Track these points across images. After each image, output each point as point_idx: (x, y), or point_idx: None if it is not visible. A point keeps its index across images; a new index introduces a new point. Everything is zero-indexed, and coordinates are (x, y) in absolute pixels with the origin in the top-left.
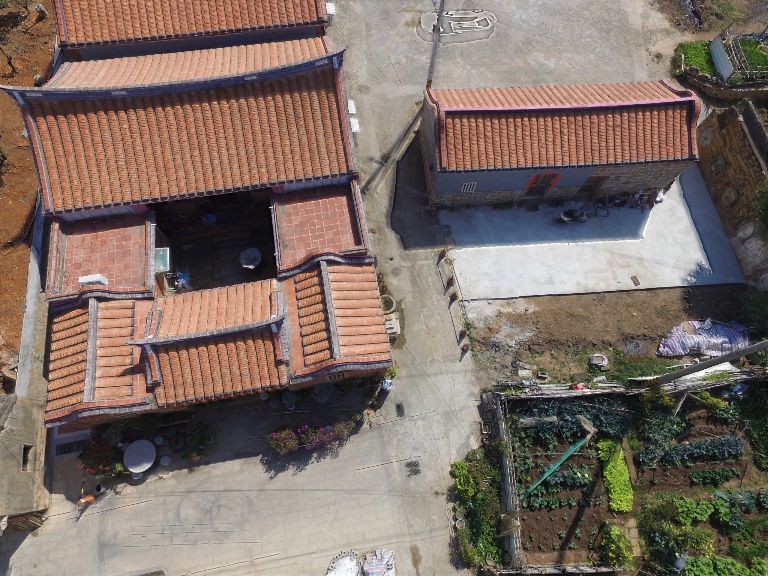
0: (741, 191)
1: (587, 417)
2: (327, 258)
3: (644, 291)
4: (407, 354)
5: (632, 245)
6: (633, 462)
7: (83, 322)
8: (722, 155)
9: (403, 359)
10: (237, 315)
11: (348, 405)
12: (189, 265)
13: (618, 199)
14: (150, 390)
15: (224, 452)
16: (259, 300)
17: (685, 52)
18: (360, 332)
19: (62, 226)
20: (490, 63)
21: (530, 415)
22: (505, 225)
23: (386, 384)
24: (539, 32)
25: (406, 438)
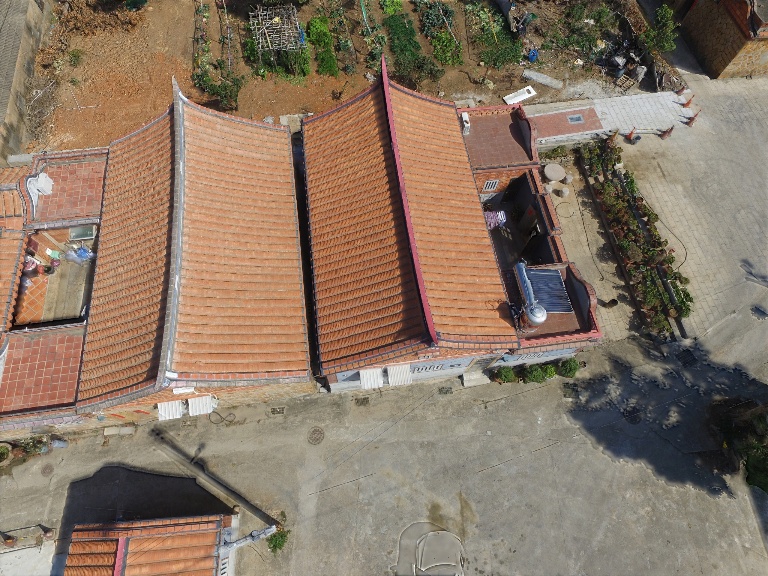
0: None
1: None
2: None
3: None
4: None
5: None
6: None
7: None
8: None
9: None
10: None
11: None
12: None
13: None
14: None
15: None
16: None
17: None
18: None
19: None
20: None
21: None
22: None
23: None
24: None
25: None
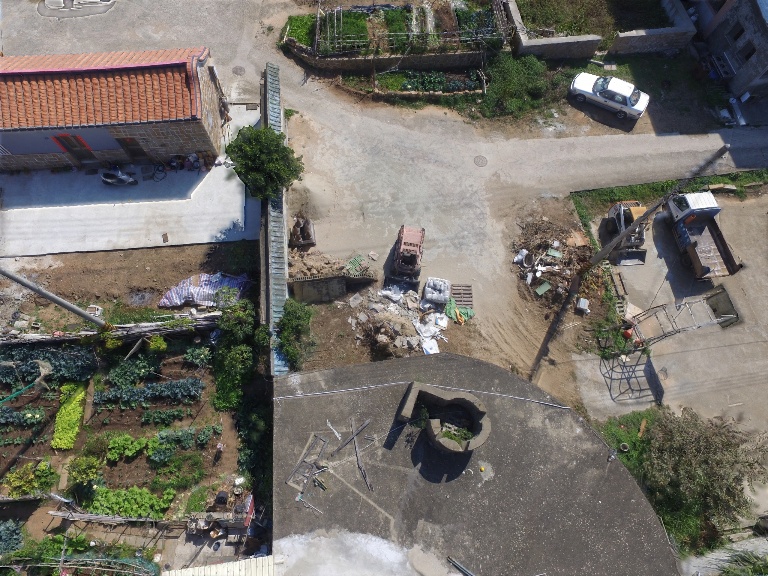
0: None
1: (51, 362)
2: None
3: (172, 248)
4: None
5: (177, 205)
6: (92, 404)
7: None
8: None
9: None
10: None
11: None
12: None
13: (173, 162)
14: None
15: None
16: None
17: (290, 24)
18: None
19: None
20: (97, 36)
21: None
22: (59, 188)
23: None
24: (158, 7)
25: None
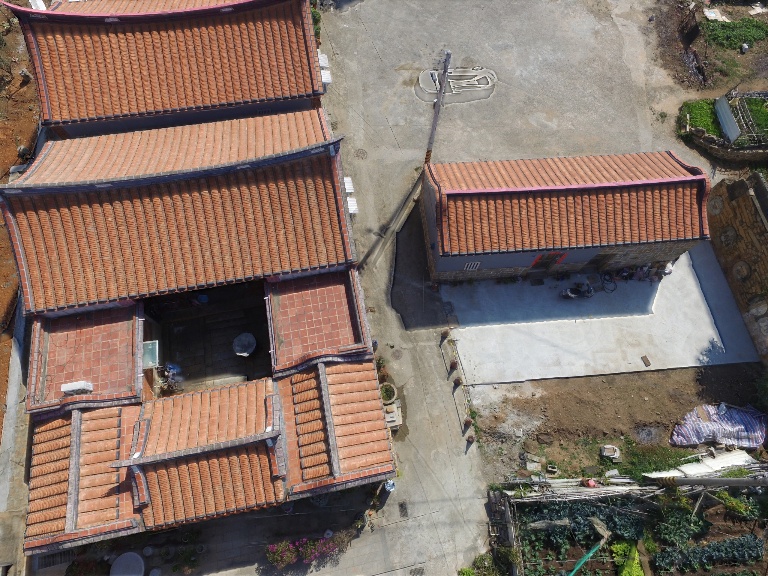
0: (753, 267)
1: (600, 518)
2: (325, 360)
3: (655, 372)
4: (410, 447)
5: (641, 321)
6: (649, 565)
7: (65, 435)
8: (732, 227)
9: (406, 452)
10: (230, 424)
11: (348, 505)
12: (180, 350)
13: (626, 272)
14: (137, 511)
15: (217, 561)
16: (253, 405)
17: (690, 112)
18: (361, 441)
19: (44, 324)
20: (491, 125)
21: (540, 516)
22: (509, 301)
23: (388, 485)
24: (540, 91)
25: (410, 542)
